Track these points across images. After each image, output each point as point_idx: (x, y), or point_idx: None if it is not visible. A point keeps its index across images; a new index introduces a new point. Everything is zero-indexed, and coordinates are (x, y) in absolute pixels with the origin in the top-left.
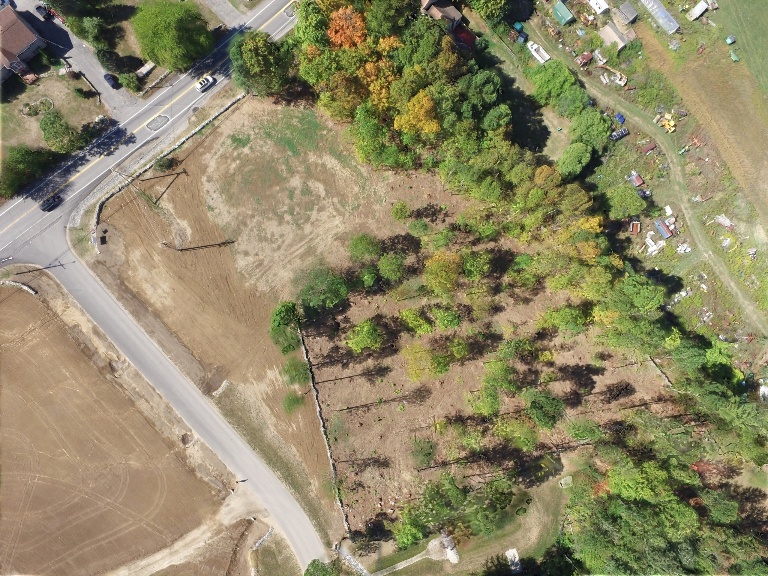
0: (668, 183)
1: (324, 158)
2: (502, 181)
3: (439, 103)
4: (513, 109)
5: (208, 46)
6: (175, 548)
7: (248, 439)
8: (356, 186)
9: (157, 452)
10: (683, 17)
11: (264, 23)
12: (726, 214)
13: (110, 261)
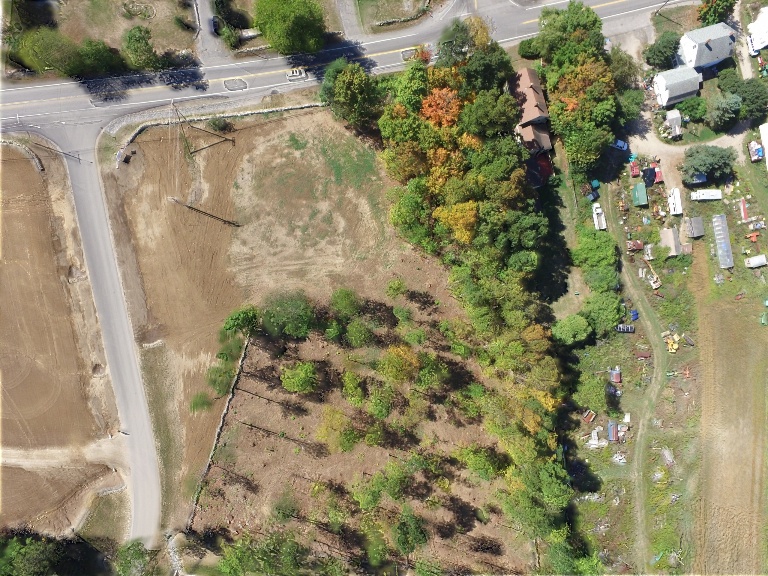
0: (642, 394)
1: (359, 200)
2: (497, 314)
3: (479, 222)
4: (548, 253)
5: (315, 49)
6: (33, 456)
7: (150, 401)
8: (372, 240)
9: (66, 366)
10: (742, 260)
11: (379, 52)
12: (675, 449)
13: (123, 180)
